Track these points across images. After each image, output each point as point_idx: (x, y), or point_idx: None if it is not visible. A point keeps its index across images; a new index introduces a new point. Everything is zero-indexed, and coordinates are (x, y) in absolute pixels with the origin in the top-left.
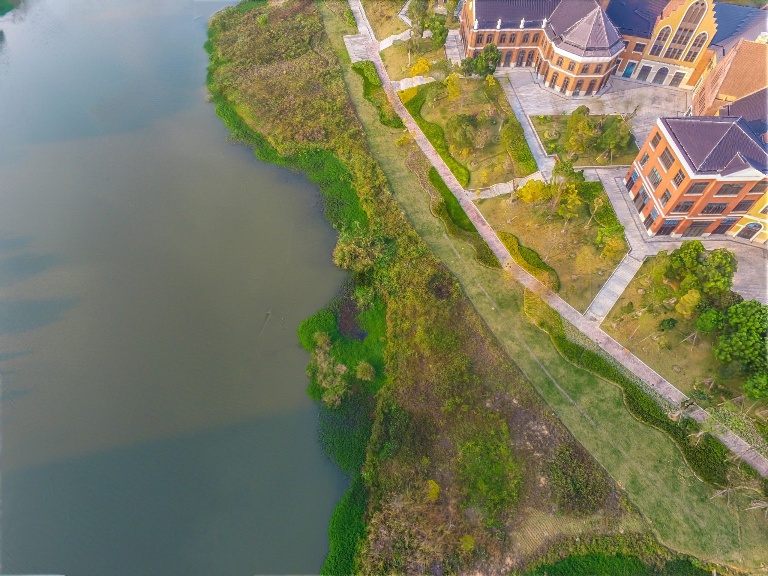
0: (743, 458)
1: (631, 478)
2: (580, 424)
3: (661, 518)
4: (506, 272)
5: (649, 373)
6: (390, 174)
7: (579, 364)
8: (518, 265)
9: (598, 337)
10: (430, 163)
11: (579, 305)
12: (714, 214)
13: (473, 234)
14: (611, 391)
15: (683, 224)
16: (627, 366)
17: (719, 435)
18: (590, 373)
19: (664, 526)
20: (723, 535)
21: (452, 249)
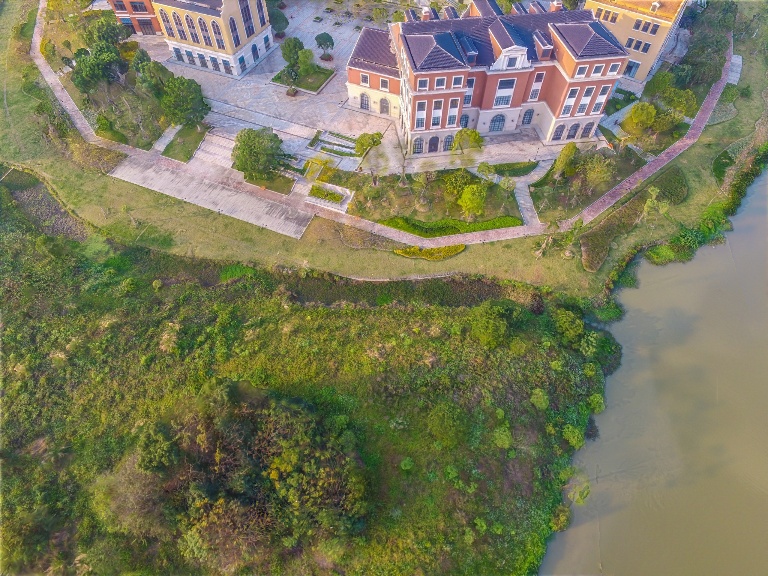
0: (79, 129)
1: (4, 134)
2: (0, 115)
3: (3, 148)
4: (29, 55)
5: (66, 97)
6: (5, 11)
7: (27, 92)
8: (40, 52)
9: (53, 83)
10: (38, 6)
11: (56, 69)
12: (143, 12)
13: (27, 38)
14: (34, 103)
15: (132, 22)
16: (56, 94)
17: (76, 121)
18: (31, 97)
19: (1, 151)
20: (30, 154)
21: (7, 45)
